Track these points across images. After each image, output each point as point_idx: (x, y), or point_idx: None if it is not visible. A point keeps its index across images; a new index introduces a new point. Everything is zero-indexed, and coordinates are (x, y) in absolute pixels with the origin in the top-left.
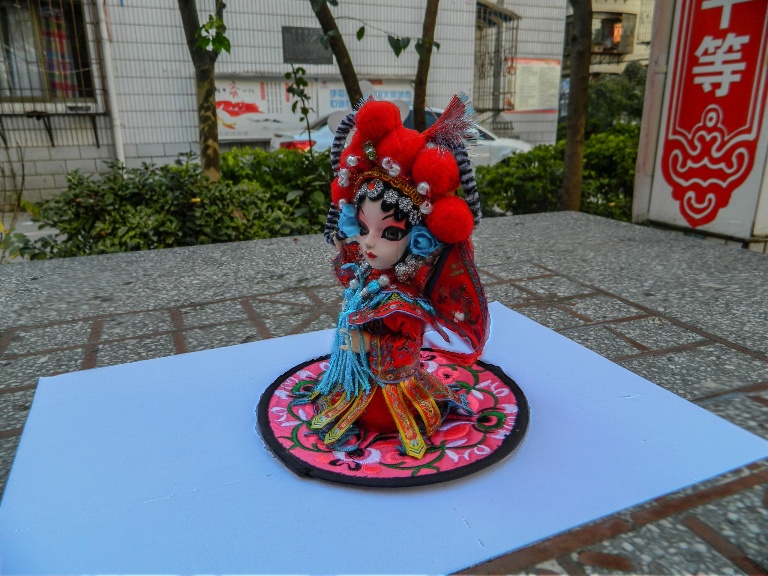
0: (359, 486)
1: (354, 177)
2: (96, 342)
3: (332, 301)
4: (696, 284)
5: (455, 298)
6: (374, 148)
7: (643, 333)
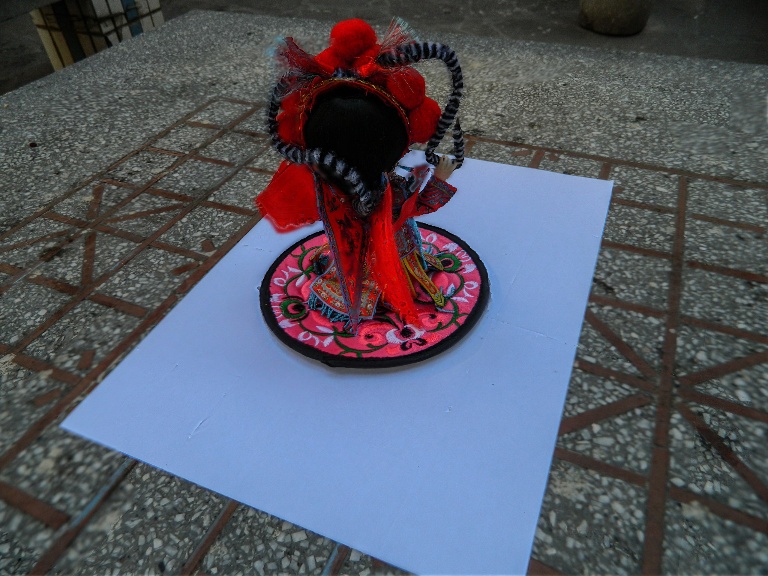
0: None
1: None
2: (686, 216)
3: (697, 413)
4: None
5: None
6: None
7: None
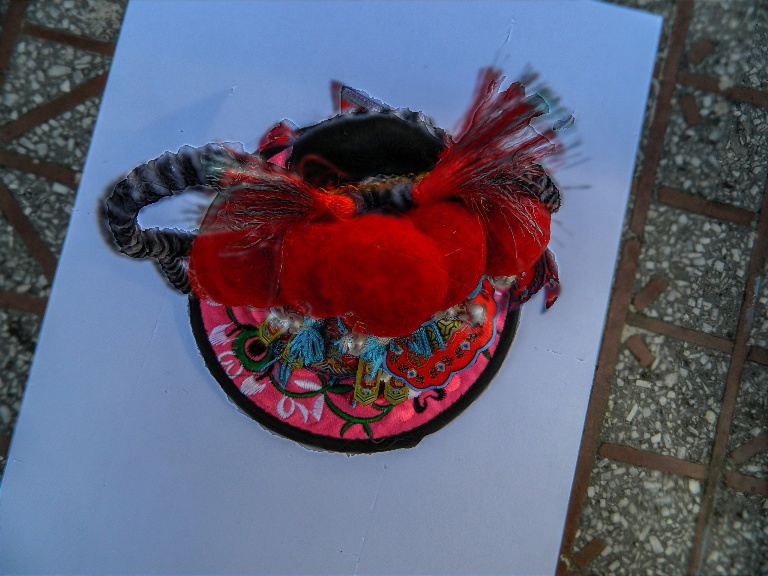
0: None
1: None
2: None
3: None
4: None
5: None
6: None
7: None
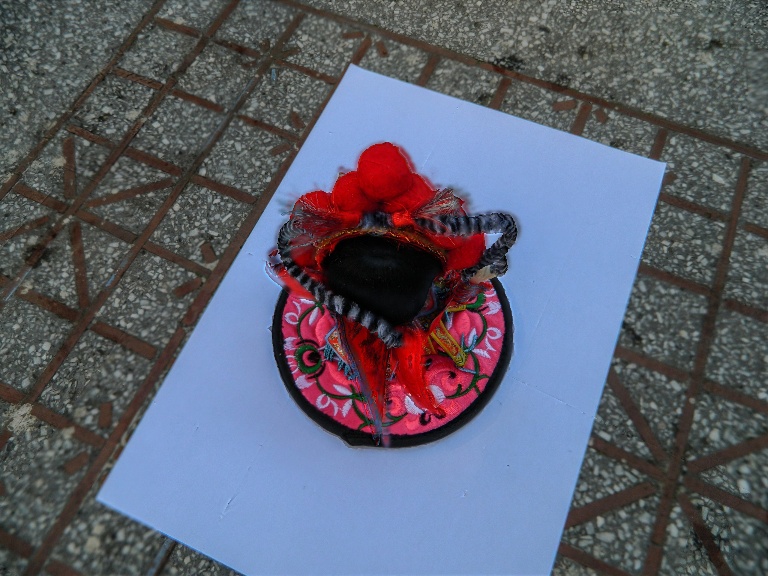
0: None
1: None
2: (738, 226)
3: (697, 507)
4: None
5: None
6: None
7: None
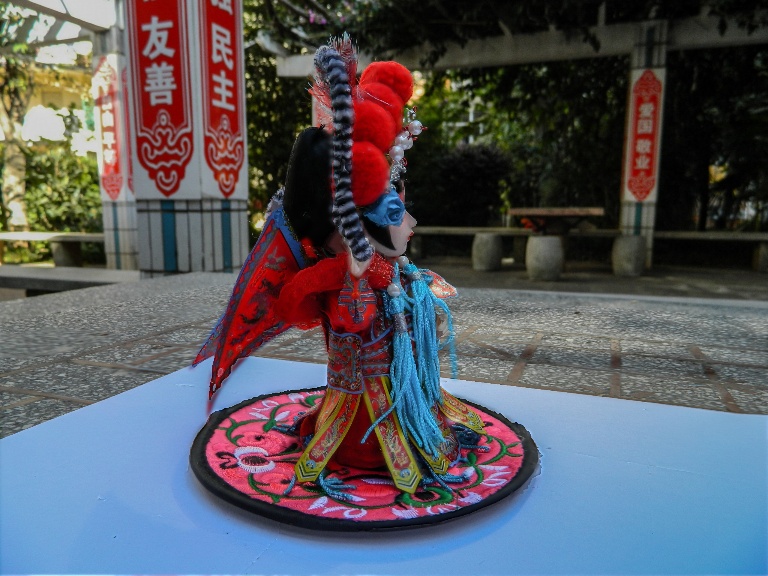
0: None
1: None
2: None
3: None
4: None
5: None
6: None
7: None
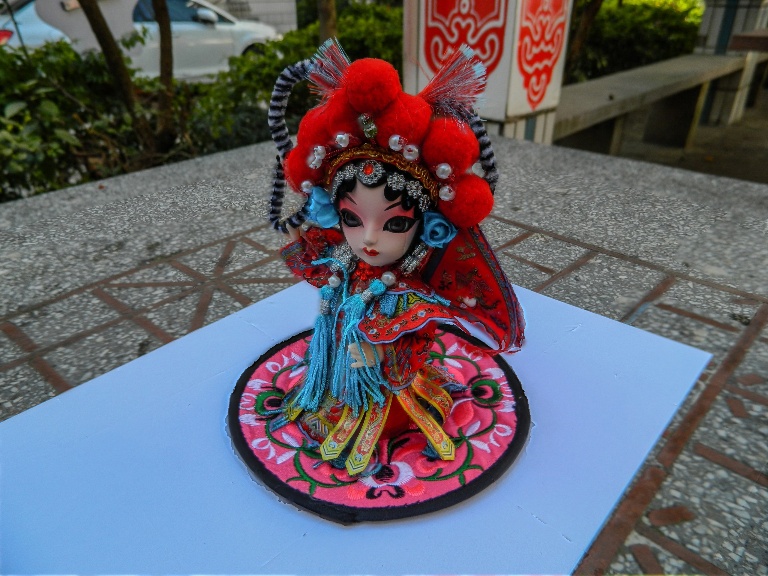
0: (418, 516)
1: (329, 155)
2: None
3: (213, 271)
4: (545, 191)
5: (463, 283)
6: (374, 124)
7: (539, 254)
